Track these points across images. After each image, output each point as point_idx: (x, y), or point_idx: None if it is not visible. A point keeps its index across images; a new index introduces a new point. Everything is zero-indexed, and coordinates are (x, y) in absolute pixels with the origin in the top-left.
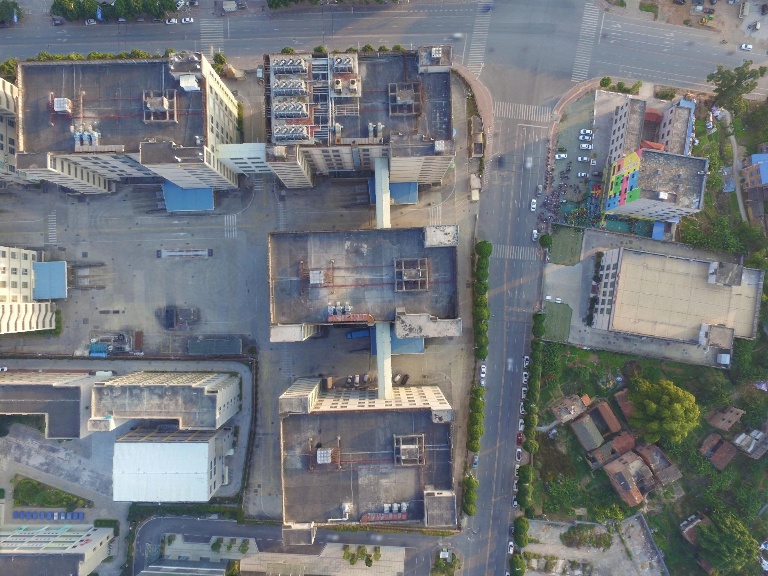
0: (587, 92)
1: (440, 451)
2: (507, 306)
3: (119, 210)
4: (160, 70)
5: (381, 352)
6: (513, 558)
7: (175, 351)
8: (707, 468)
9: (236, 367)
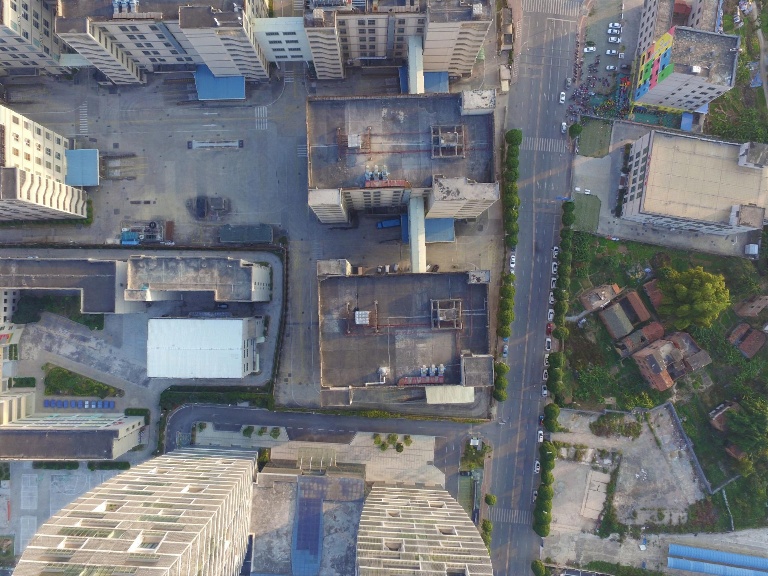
0: None
1: (477, 316)
2: (536, 197)
3: (150, 101)
4: None
5: (415, 228)
6: (543, 444)
7: (206, 241)
8: (736, 356)
9: (266, 257)
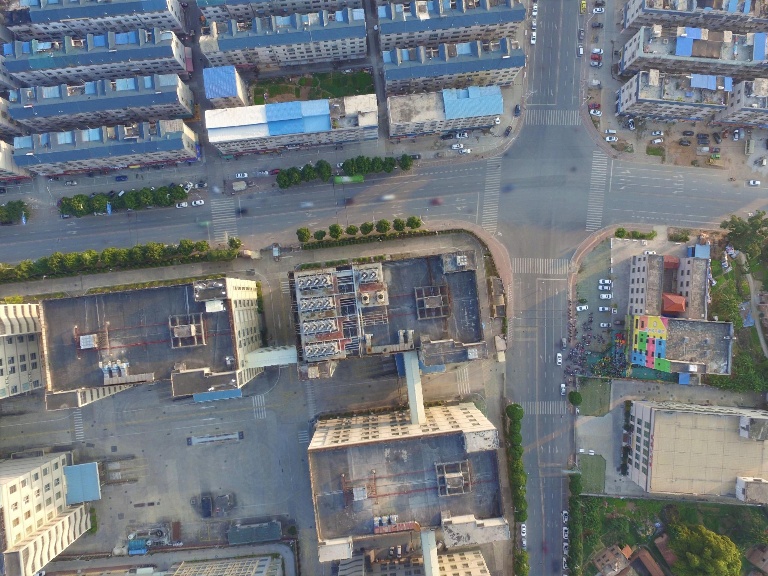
0: (602, 241)
1: None
2: (541, 462)
3: (145, 401)
4: (183, 292)
5: (426, 543)
6: None
7: (214, 538)
8: None
9: (277, 548)
